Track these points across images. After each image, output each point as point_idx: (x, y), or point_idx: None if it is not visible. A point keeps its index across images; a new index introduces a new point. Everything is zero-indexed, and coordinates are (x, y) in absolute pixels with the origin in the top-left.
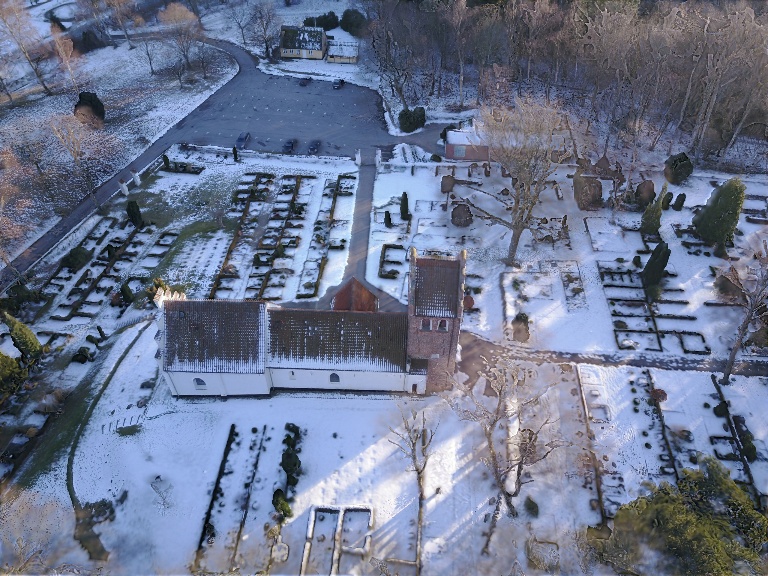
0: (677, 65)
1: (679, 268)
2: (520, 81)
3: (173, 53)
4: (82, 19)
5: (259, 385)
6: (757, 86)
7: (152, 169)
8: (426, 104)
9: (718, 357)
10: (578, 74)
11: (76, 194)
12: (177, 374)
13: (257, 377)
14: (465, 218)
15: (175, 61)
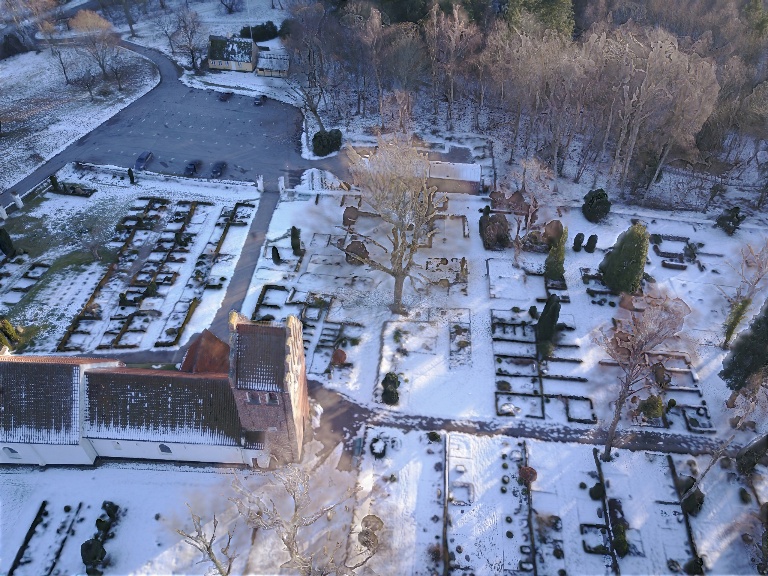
0: (611, 91)
1: (579, 320)
2: (449, 103)
3: None
4: (2, 22)
5: (79, 455)
6: (678, 120)
7: (39, 190)
8: (346, 125)
9: (604, 427)
10: (517, 95)
11: None
12: None
13: (73, 448)
14: None
15: (95, 70)
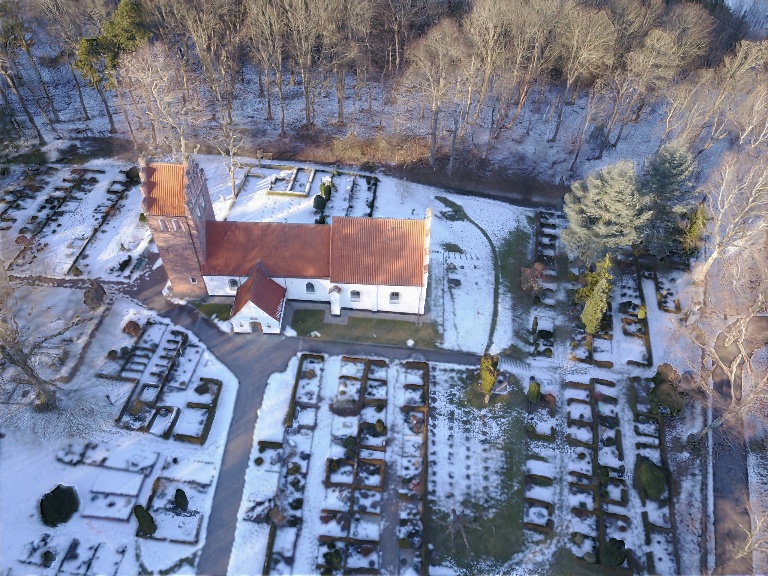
0: None
1: None
2: None
3: None
4: None
5: None
6: None
7: None
8: None
9: None
10: None
11: None
12: None
13: None
14: None
15: None
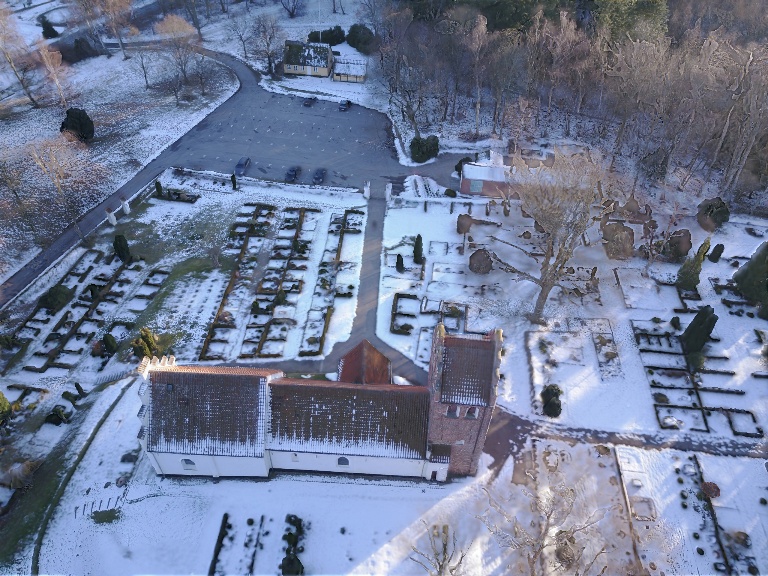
0: (706, 98)
1: (721, 331)
2: (538, 109)
3: (170, 65)
4: (74, 26)
5: (257, 467)
6: None
7: (143, 196)
8: (439, 131)
9: None
10: (597, 101)
11: (59, 222)
12: (163, 454)
13: (255, 460)
14: (485, 265)
15: (172, 74)
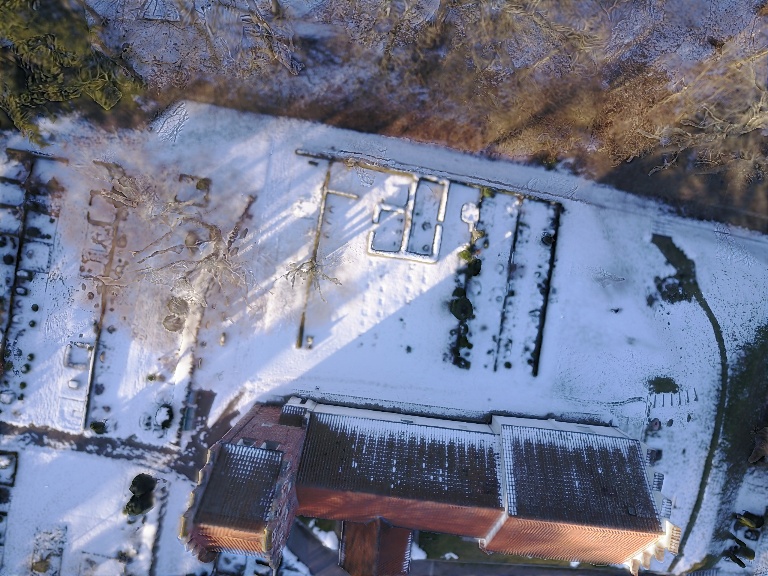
0: None
1: None
2: None
3: None
4: None
5: None
6: None
7: None
8: None
9: None
10: None
11: None
12: None
13: None
14: None
15: None
